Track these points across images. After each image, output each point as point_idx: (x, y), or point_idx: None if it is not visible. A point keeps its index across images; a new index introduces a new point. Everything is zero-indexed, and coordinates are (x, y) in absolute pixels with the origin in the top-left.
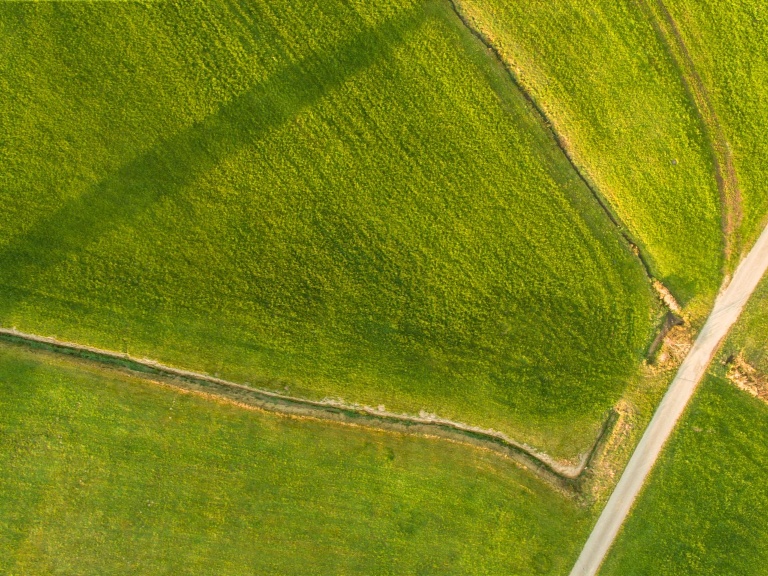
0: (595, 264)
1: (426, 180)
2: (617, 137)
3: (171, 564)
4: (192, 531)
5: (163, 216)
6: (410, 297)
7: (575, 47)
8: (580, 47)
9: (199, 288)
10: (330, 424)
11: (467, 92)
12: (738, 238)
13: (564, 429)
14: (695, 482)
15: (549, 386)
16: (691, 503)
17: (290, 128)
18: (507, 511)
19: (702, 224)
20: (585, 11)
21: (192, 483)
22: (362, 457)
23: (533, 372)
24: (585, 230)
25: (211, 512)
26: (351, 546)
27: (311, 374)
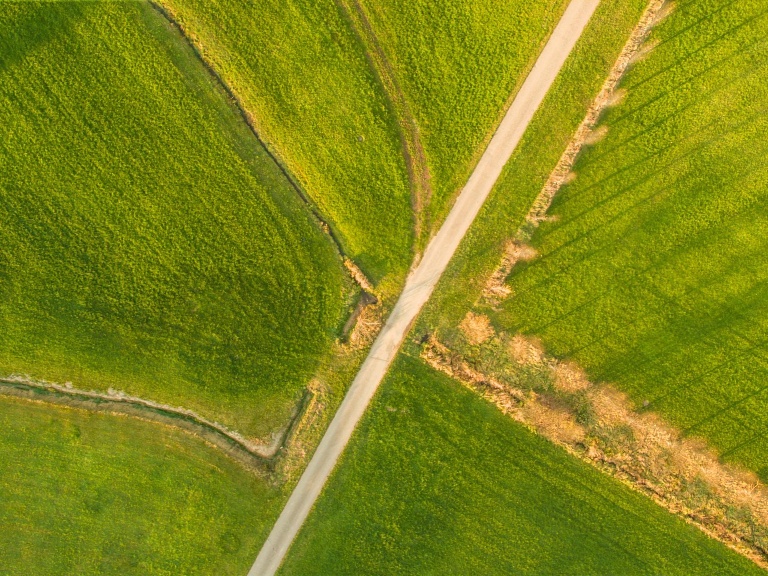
0: (284, 241)
1: (111, 156)
2: (302, 113)
3: None
4: None
5: None
6: (97, 274)
7: (257, 22)
8: (262, 22)
9: None
10: (16, 401)
11: (149, 67)
12: (427, 216)
13: (256, 408)
14: (390, 462)
15: (240, 364)
16: (386, 484)
17: None
18: (196, 490)
19: (391, 202)
20: None
21: None
22: (48, 434)
23: (223, 350)
24: (273, 207)
25: None
26: (36, 523)
27: None
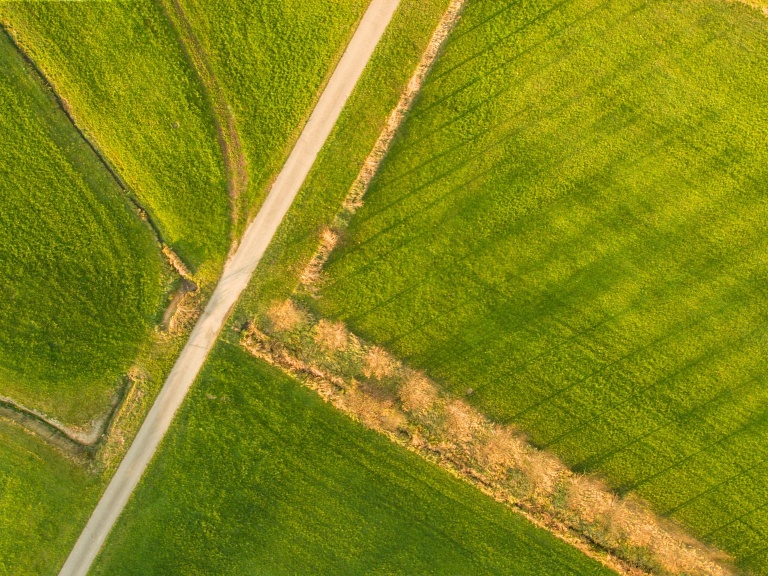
0: (101, 228)
1: None
2: (116, 100)
3: None
4: None
5: None
6: None
7: (69, 8)
8: (74, 8)
9: None
10: None
11: None
12: (244, 203)
13: (75, 395)
14: (210, 450)
15: (59, 351)
16: (206, 471)
17: None
18: (14, 477)
19: (207, 188)
20: None
21: None
22: None
23: (42, 337)
24: (89, 194)
25: None
26: None
27: None
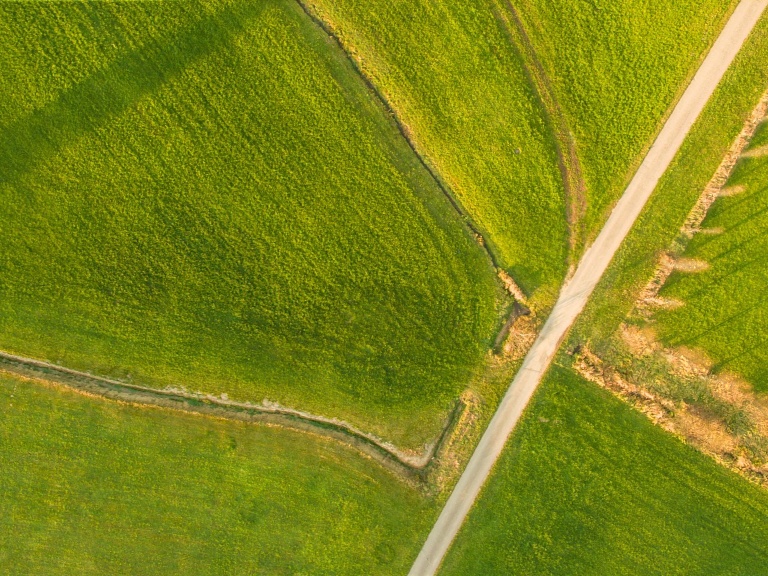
0: (439, 253)
1: (268, 168)
2: (459, 126)
3: (11, 551)
4: (32, 518)
5: (4, 203)
6: (253, 285)
7: (416, 35)
8: (421, 35)
9: (41, 275)
10: (172, 412)
11: (308, 80)
12: (582, 228)
13: (409, 419)
14: (541, 473)
15: (394, 376)
16: (537, 494)
17: (131, 115)
18: (350, 501)
19: (546, 214)
20: None
21: (33, 470)
22: (204, 445)
23: (378, 361)
24: (428, 219)
25: (51, 500)
26: (192, 535)
27: (153, 362)
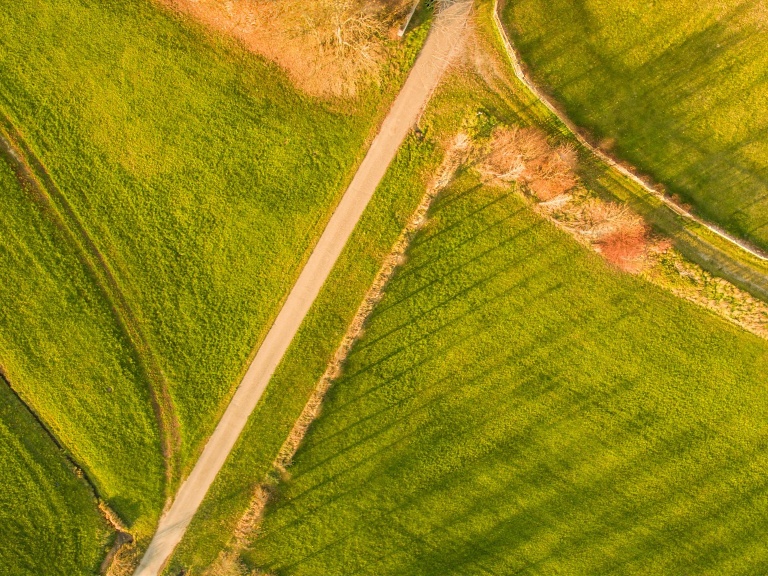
0: (38, 486)
1: None
2: (51, 365)
3: None
4: None
5: None
6: None
7: (3, 279)
8: (8, 279)
9: None
10: None
11: None
12: (178, 462)
13: None
14: None
15: None
16: None
17: None
18: None
19: (142, 448)
20: (11, 245)
21: None
22: None
23: None
24: (26, 454)
25: None
26: None
27: None
